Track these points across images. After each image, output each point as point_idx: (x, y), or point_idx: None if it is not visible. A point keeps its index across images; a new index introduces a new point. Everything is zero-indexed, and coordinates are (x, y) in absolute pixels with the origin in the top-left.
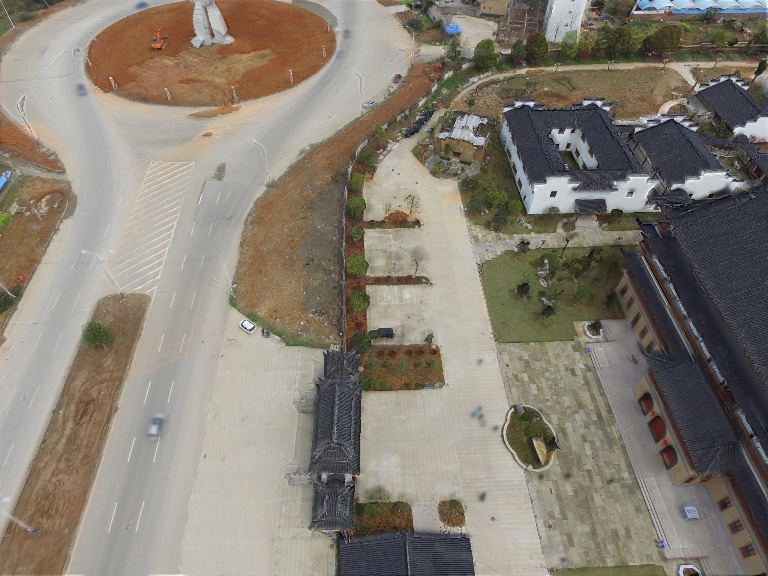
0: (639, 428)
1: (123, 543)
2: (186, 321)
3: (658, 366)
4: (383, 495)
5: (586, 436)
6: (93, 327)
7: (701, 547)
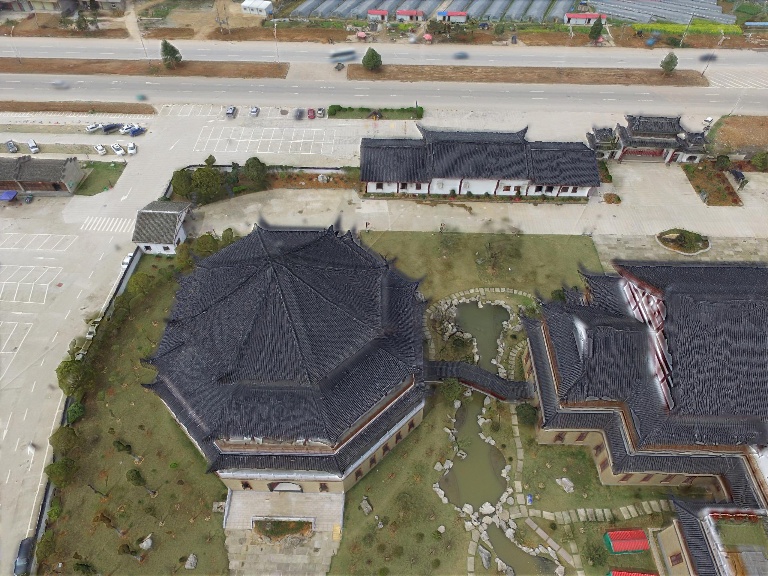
0: None
1: (561, 96)
2: (698, 101)
3: None
4: (613, 174)
5: None
6: (674, 60)
7: None
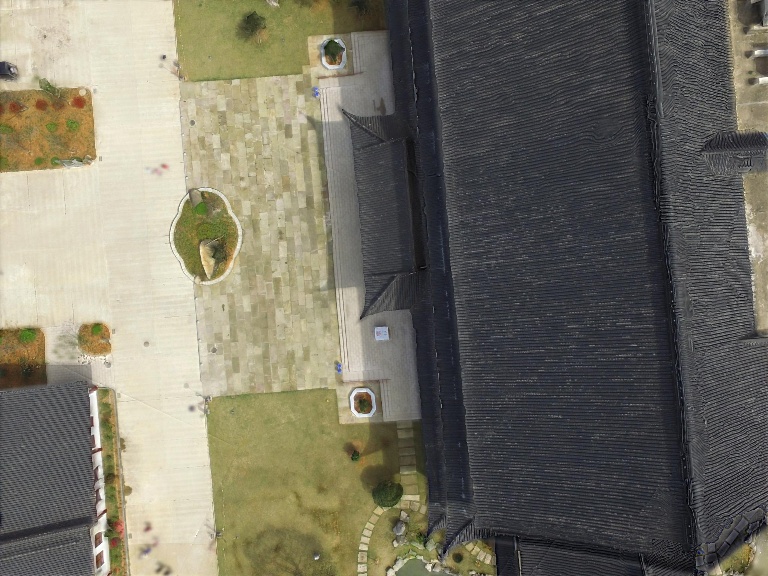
0: (357, 219)
1: None
2: None
3: (363, 139)
4: (9, 321)
5: (284, 232)
6: None
7: (385, 369)
